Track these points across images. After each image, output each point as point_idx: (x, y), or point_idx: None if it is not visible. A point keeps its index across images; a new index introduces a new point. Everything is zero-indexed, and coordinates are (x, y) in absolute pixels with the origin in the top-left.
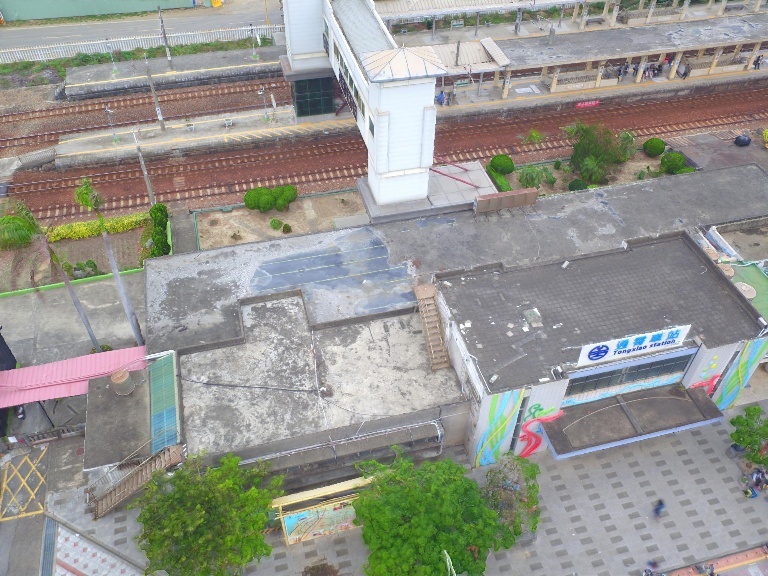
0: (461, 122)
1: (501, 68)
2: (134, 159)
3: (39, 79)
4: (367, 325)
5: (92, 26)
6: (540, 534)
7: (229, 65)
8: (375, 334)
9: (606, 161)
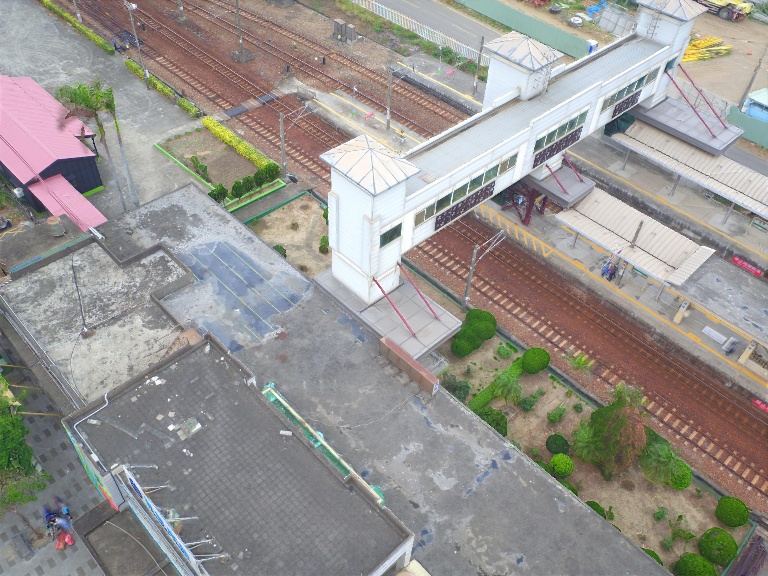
0: (604, 306)
1: (665, 282)
2: (346, 134)
3: (404, 49)
4: (175, 330)
5: (496, 35)
6: (34, 562)
7: None
8: (166, 339)
9: (600, 449)
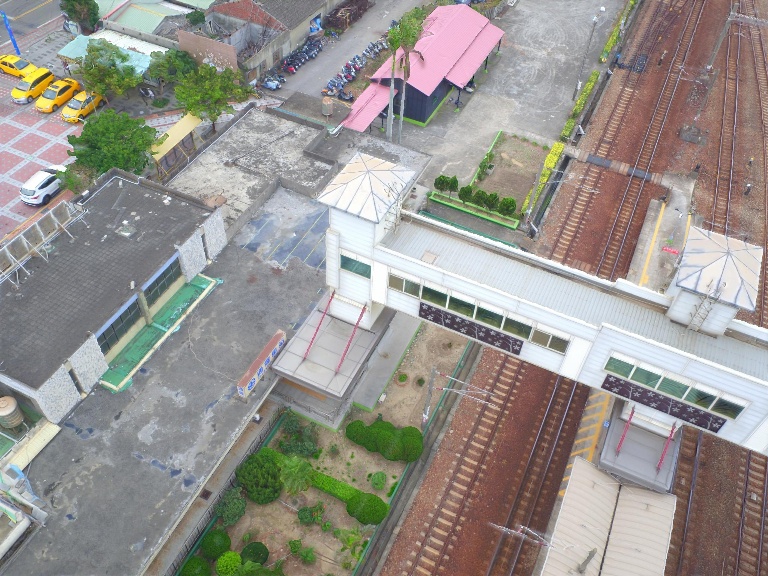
0: None
1: None
2: None
3: None
4: None
5: None
6: None
7: None
8: (240, 203)
9: None
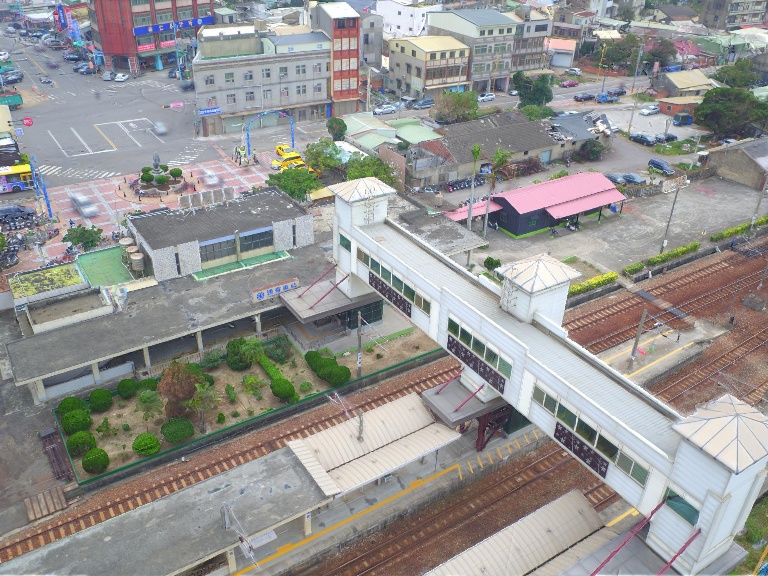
0: None
1: None
2: None
3: None
4: None
5: None
6: None
7: None
8: None
9: None
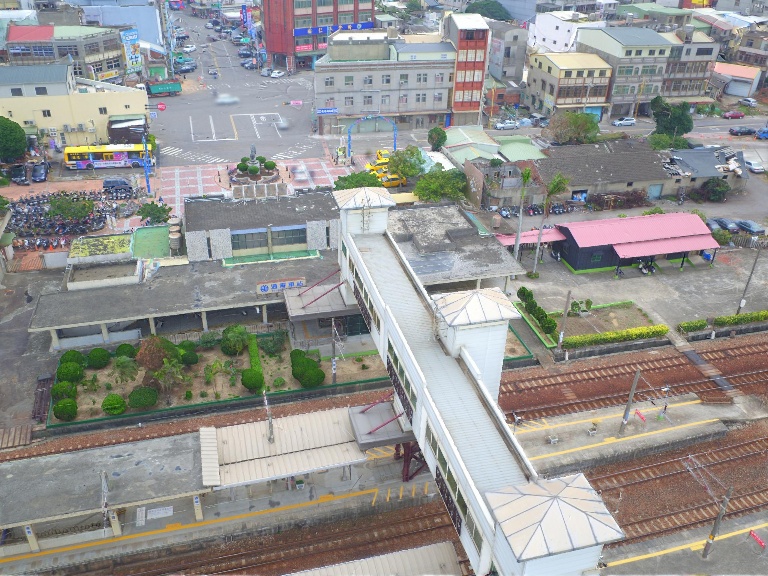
0: None
1: None
2: None
3: None
4: None
5: None
6: None
7: (621, 568)
8: None
9: None
